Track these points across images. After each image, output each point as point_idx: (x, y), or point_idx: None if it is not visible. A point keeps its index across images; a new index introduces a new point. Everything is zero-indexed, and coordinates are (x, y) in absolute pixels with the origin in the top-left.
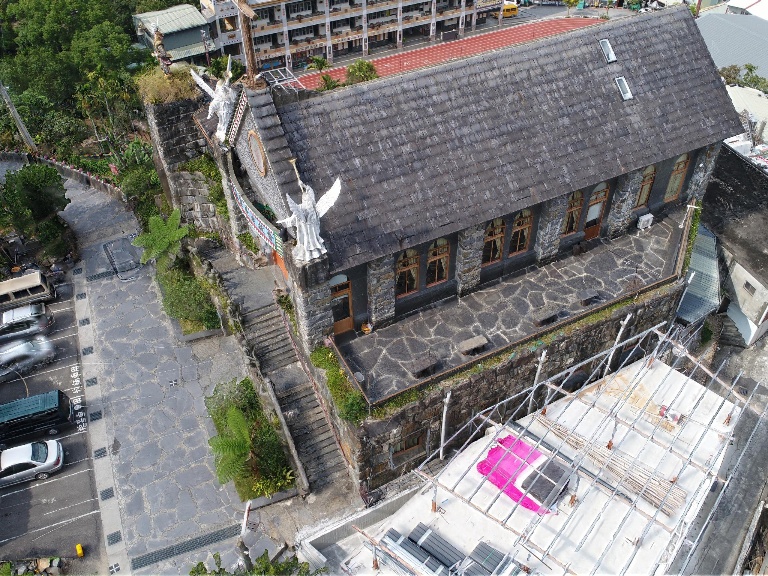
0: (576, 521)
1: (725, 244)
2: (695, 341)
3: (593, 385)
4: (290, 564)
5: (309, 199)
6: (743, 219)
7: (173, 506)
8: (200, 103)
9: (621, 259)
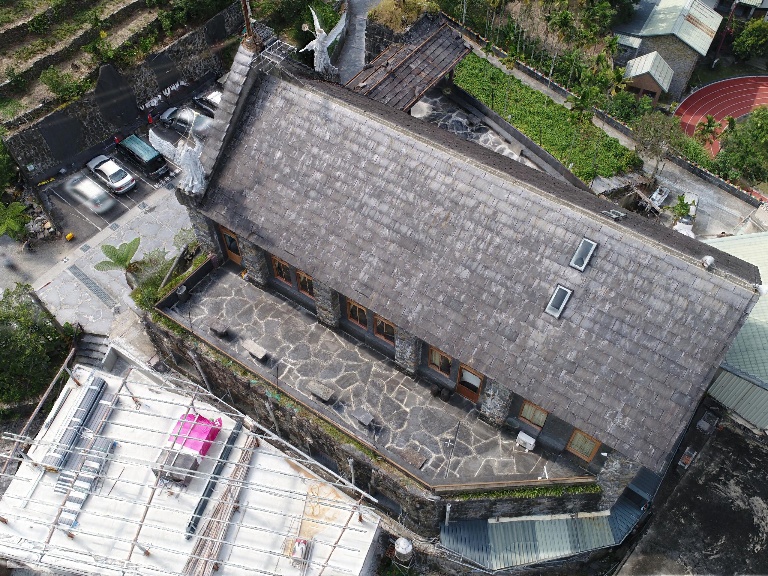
0: (157, 501)
1: (622, 561)
2: (476, 575)
3: (314, 475)
4: (43, 330)
5: (180, 146)
6: (694, 575)
7: None
8: (401, 39)
9: (452, 435)
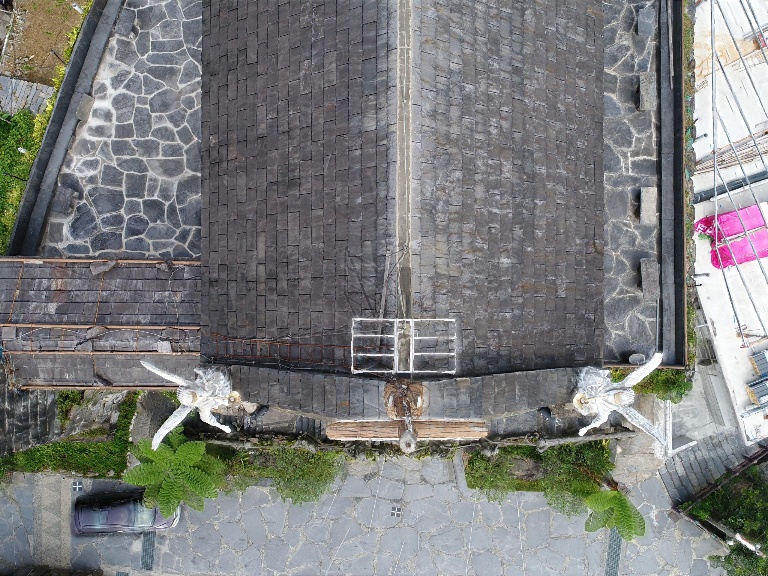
0: None
1: None
2: None
3: None
4: None
5: None
6: None
7: (563, 559)
8: None
9: None
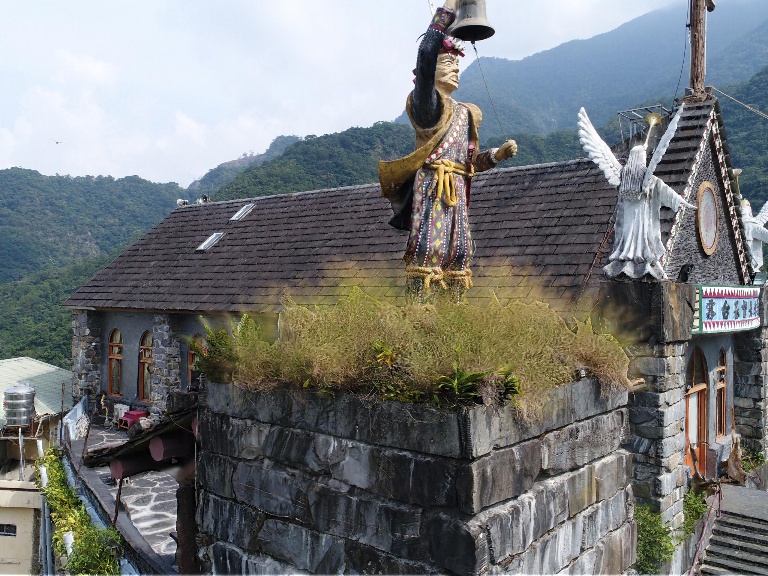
0: None
1: None
2: None
3: None
4: None
5: None
6: None
7: None
8: None
9: None
